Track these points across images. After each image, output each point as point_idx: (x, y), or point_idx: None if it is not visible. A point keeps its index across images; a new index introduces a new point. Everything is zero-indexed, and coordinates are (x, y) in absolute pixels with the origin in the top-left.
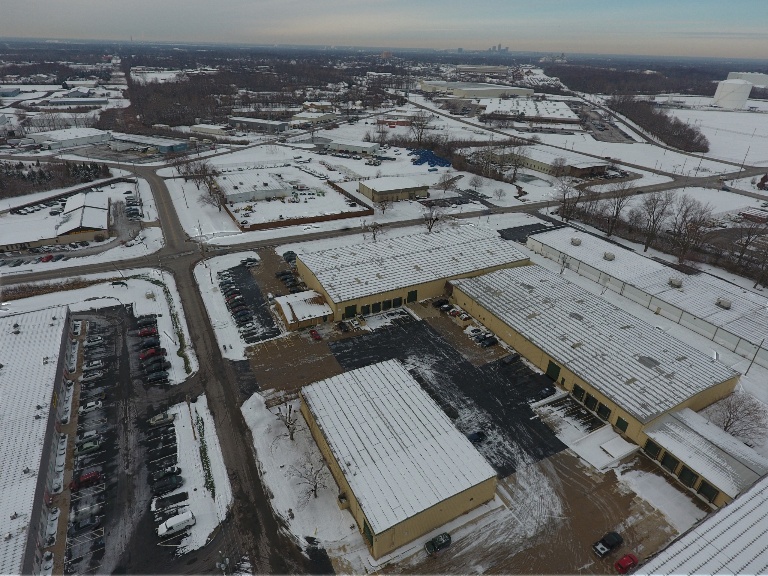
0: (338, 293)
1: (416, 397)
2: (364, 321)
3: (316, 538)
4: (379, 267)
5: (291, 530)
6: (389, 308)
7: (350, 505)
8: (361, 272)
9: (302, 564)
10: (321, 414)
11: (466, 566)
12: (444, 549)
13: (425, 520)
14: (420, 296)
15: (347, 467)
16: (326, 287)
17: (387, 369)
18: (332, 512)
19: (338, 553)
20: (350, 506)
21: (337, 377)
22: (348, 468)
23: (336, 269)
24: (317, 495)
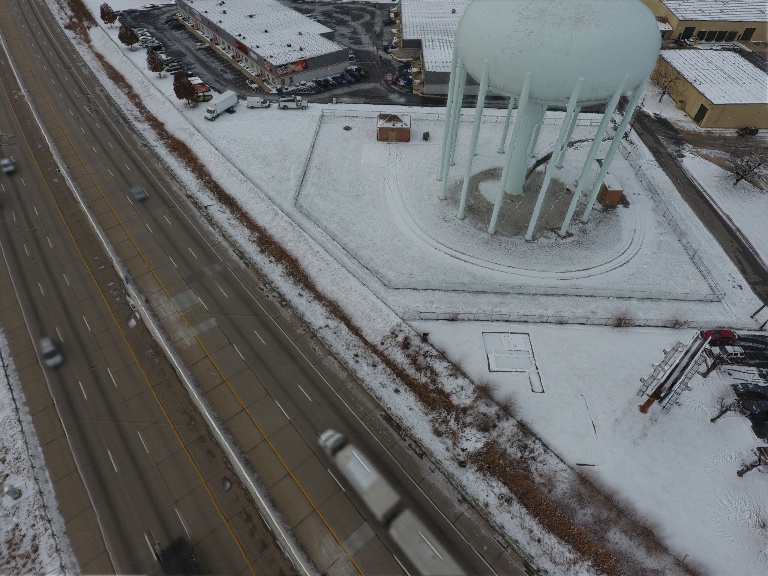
0: (683, 14)
1: (750, 69)
2: (699, 41)
3: (660, 114)
4: (723, 5)
5: (643, 109)
6: (721, 40)
7: (685, 108)
8: (705, 6)
9: (652, 120)
10: (673, 61)
11: (765, 144)
12: (751, 136)
13: (745, 115)
14: (755, 36)
15: (694, 81)
16: (672, 10)
17: (726, 54)
18: (671, 109)
19: (676, 121)
20: (685, 109)
21: (684, 50)
22: (695, 82)
23: (682, 1)
24: (661, 101)
